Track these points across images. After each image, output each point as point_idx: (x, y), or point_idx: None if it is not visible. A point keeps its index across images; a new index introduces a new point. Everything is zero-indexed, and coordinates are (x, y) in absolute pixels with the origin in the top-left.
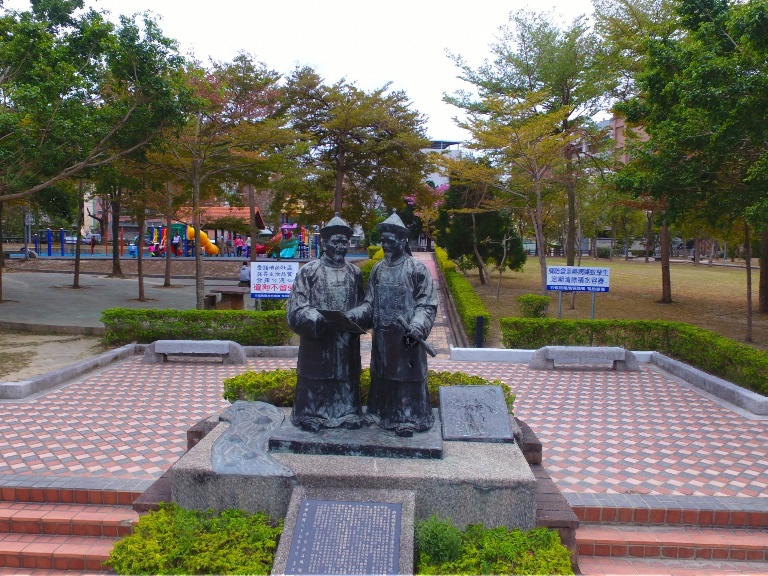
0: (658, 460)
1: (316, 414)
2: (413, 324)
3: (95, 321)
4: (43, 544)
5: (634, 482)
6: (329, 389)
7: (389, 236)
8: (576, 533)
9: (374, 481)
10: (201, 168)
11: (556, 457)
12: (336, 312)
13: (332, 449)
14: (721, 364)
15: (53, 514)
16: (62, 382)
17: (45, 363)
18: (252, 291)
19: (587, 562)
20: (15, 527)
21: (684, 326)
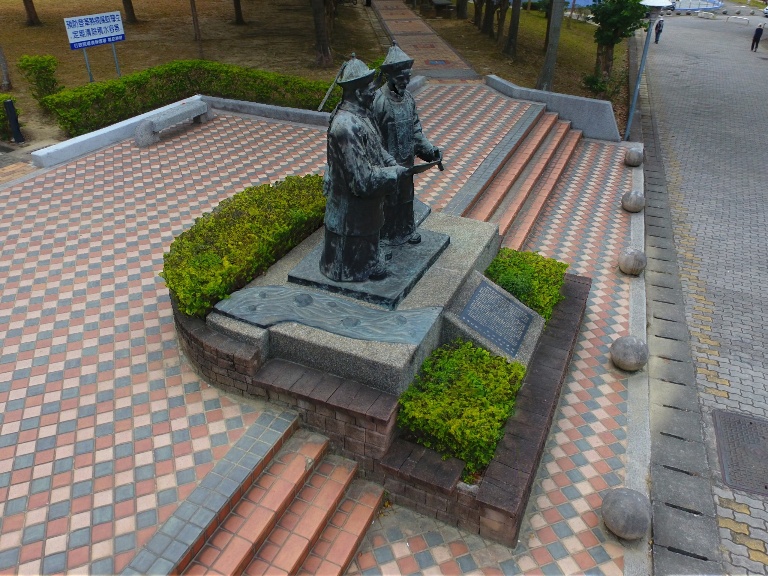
0: None
1: None
2: None
3: None
4: (283, 552)
5: None
6: None
7: (408, 73)
8: None
9: None
10: None
11: None
12: None
13: None
14: (269, 94)
15: (250, 531)
16: None
17: None
18: None
19: None
20: None
21: (208, 64)
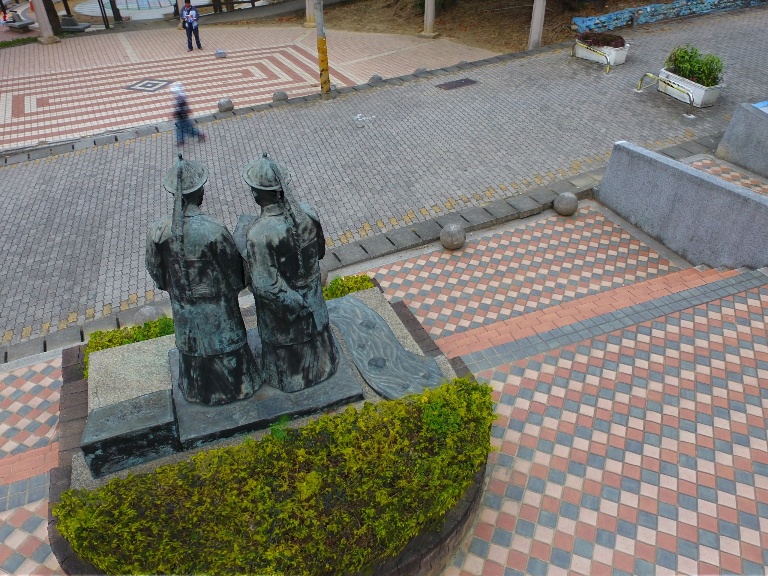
0: None
1: None
2: None
3: None
4: None
5: None
6: None
7: None
8: None
9: None
10: None
11: None
12: (246, 216)
13: None
14: None
15: (508, 337)
16: None
17: None
18: None
19: None
20: None
21: None
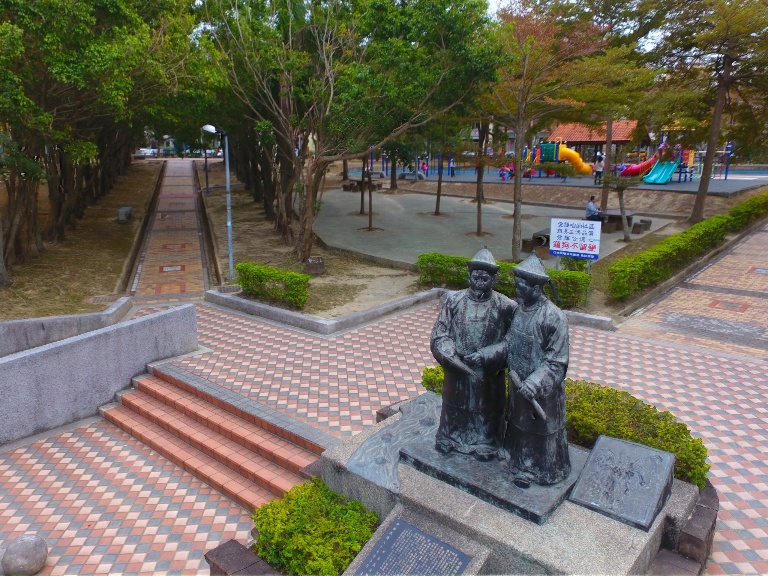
0: None
1: (449, 436)
2: (527, 381)
3: None
4: (269, 471)
5: None
6: (463, 417)
7: (519, 281)
8: None
9: (457, 525)
10: (525, 113)
11: (765, 552)
12: None
13: (445, 477)
14: None
15: (280, 451)
16: (364, 322)
17: (366, 299)
18: (551, 247)
19: None
20: (260, 452)
21: None
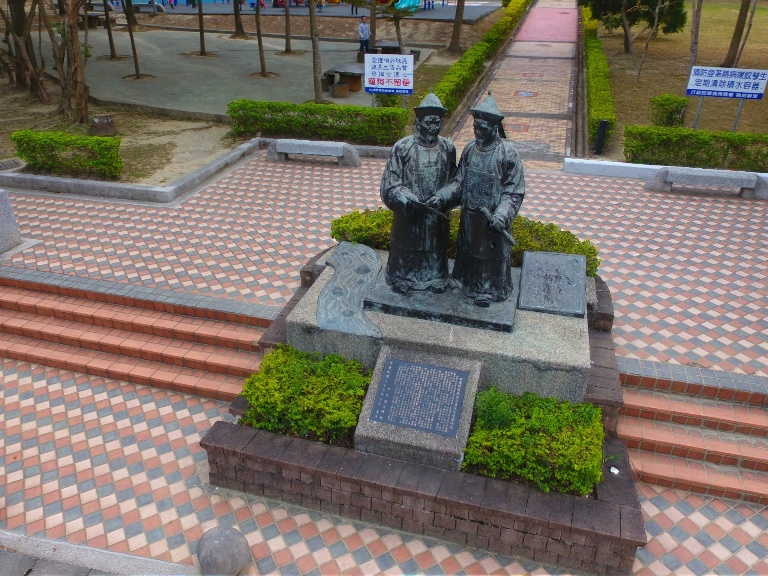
0: (736, 328)
1: (405, 278)
2: (497, 215)
3: (223, 106)
4: (198, 352)
5: (700, 353)
6: (418, 258)
7: (481, 123)
8: (627, 397)
9: (448, 350)
10: None
11: (633, 314)
12: (423, 205)
13: (416, 314)
14: None
15: (203, 329)
16: (200, 184)
17: (184, 158)
18: (367, 85)
19: (630, 423)
20: (177, 336)
21: None
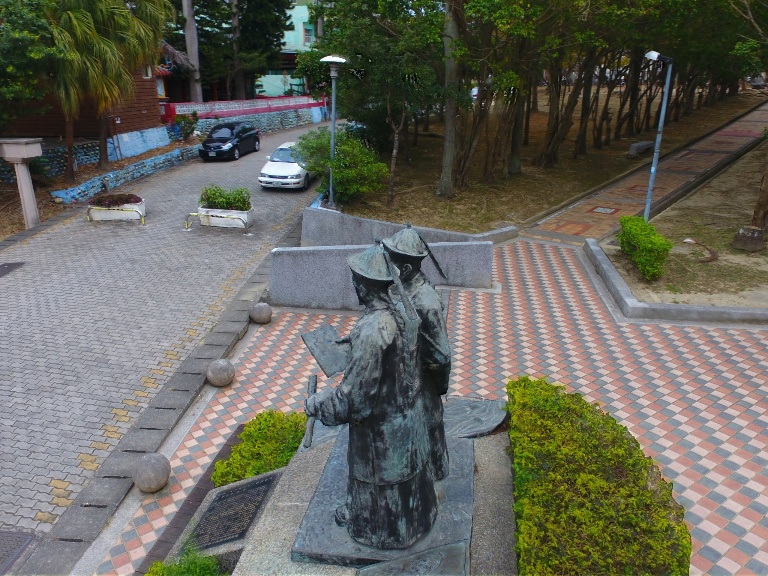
0: None
1: None
2: None
3: None
4: None
5: None
6: None
7: None
8: None
9: None
10: None
11: None
12: None
13: None
14: None
15: None
16: (698, 320)
17: (757, 296)
18: None
19: None
20: None
21: None
